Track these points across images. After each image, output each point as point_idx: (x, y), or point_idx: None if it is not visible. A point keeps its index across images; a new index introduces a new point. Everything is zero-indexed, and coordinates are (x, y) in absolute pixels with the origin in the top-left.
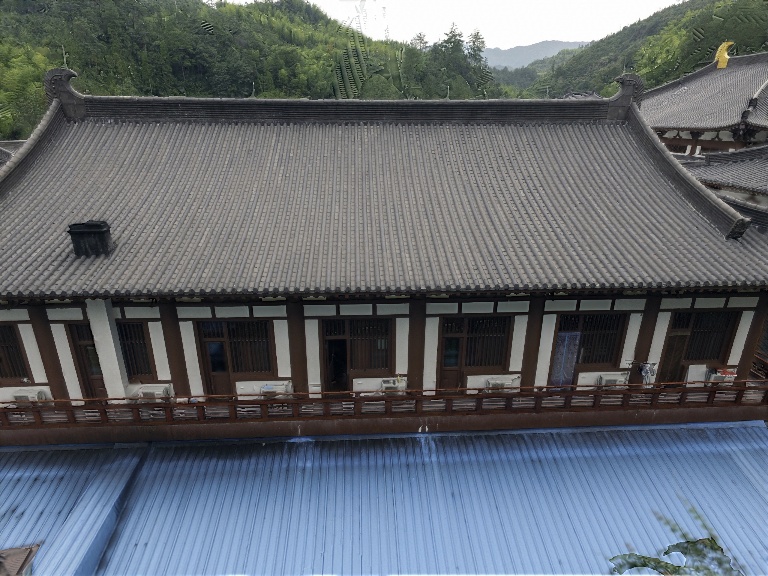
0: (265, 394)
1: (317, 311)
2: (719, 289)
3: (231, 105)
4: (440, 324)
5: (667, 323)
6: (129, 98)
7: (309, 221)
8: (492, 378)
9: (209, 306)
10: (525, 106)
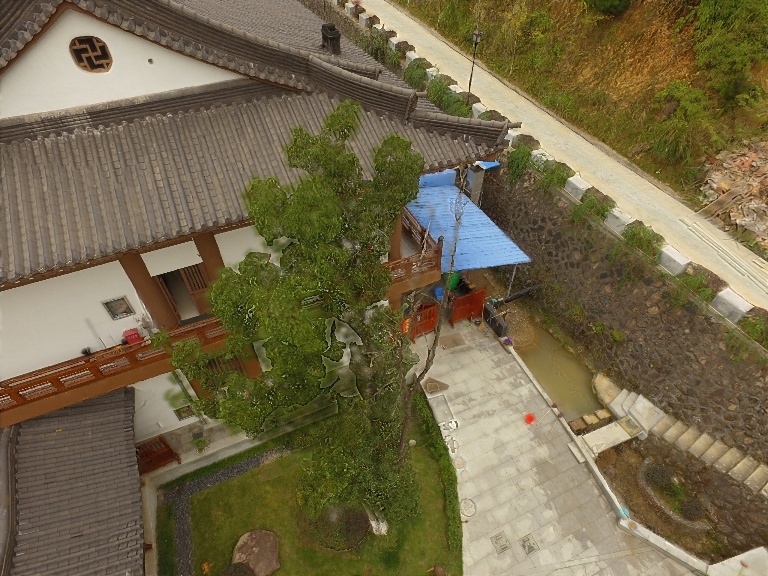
0: None
1: None
2: None
3: None
4: None
5: None
6: None
7: (253, 5)
8: None
9: None
10: None
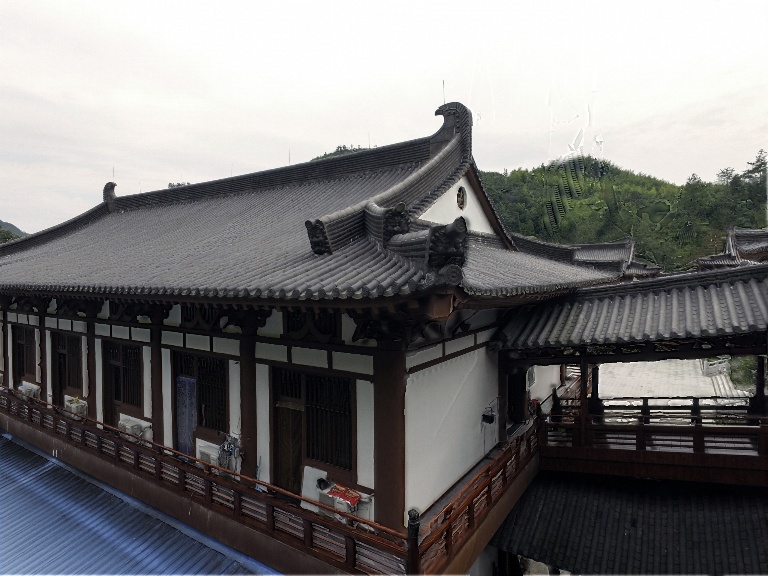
0: (0, 385)
1: (50, 323)
2: (187, 302)
3: (169, 192)
4: (102, 347)
5: (267, 382)
6: None
7: None
8: (127, 419)
9: (16, 313)
10: (347, 159)
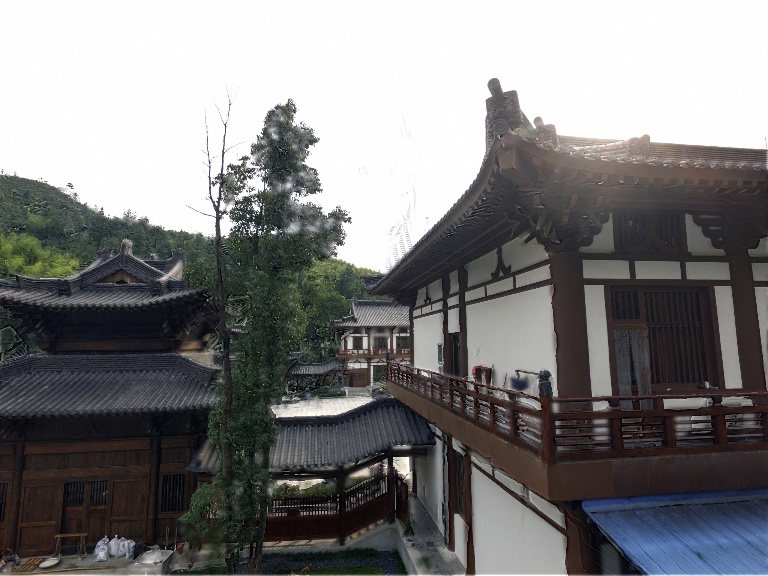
0: None
1: None
2: None
3: (661, 147)
4: None
5: None
6: (565, 136)
7: None
8: None
9: None
10: None
